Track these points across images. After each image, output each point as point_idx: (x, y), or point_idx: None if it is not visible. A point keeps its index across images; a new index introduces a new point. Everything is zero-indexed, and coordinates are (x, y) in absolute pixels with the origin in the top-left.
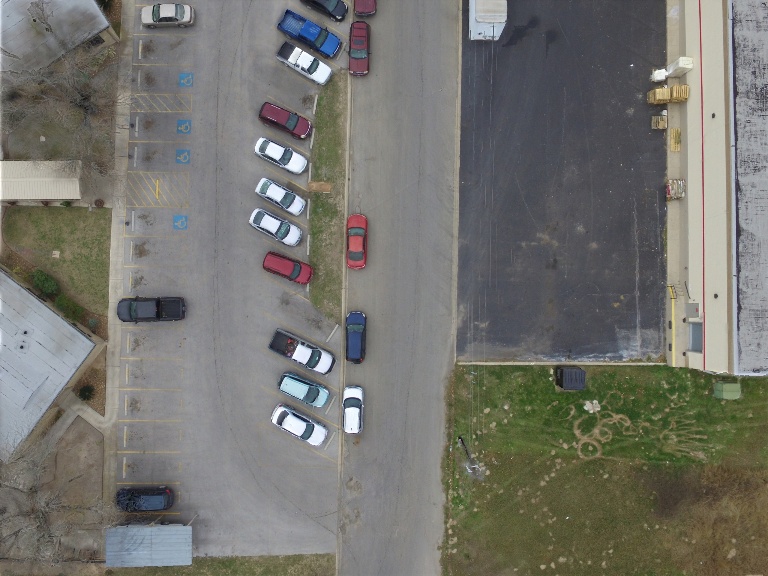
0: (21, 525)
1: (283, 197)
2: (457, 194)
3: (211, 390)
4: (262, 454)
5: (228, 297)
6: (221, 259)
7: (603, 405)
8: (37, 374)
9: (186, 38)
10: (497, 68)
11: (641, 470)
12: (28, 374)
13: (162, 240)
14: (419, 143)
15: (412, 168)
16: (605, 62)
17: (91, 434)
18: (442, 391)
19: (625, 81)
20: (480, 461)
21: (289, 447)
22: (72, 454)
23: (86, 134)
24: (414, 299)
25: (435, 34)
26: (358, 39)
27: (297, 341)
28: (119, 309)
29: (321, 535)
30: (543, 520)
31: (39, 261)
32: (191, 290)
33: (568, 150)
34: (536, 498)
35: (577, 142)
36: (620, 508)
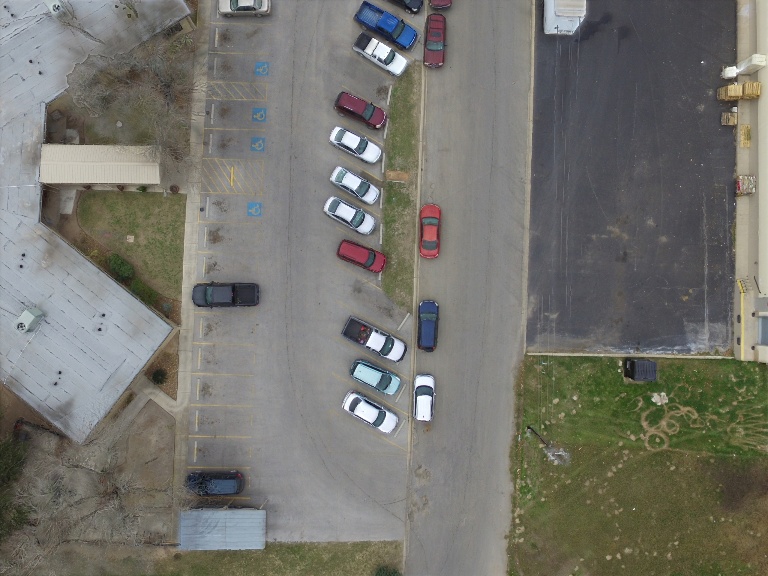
0: (97, 506)
1: (359, 186)
2: (528, 186)
3: (283, 376)
4: (332, 440)
5: (301, 284)
6: (294, 246)
7: (671, 397)
8: (115, 356)
9: (262, 27)
10: (570, 62)
11: (708, 463)
12: (106, 356)
13: (236, 226)
14: (492, 135)
15: (484, 160)
16: (676, 58)
17: (163, 418)
18: (511, 381)
19: (695, 78)
20: (548, 451)
21: (359, 434)
22: (144, 437)
23: (163, 120)
24: (485, 289)
25: (508, 28)
26: (435, 31)
27: (370, 328)
28: (194, 294)
29: (389, 522)
30: (610, 511)
31: (113, 245)
32: (264, 276)
33: (639, 145)
34: (603, 489)
35: (648, 137)
36: (686, 500)
